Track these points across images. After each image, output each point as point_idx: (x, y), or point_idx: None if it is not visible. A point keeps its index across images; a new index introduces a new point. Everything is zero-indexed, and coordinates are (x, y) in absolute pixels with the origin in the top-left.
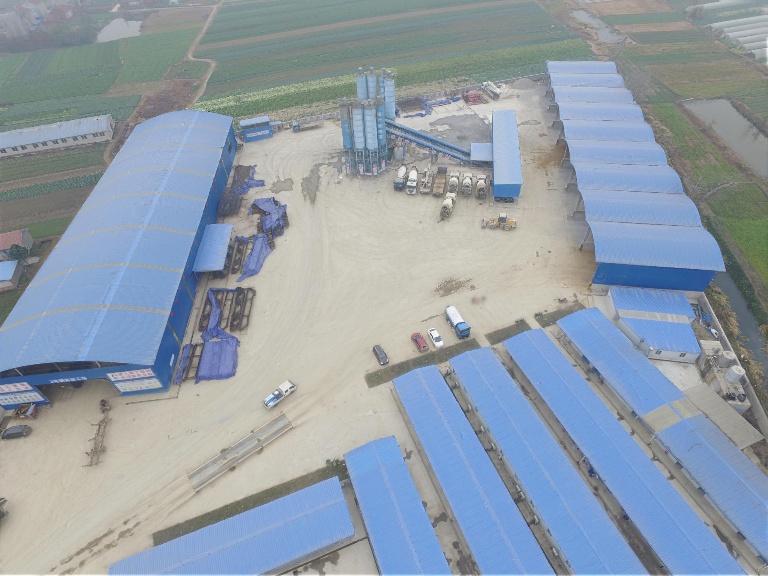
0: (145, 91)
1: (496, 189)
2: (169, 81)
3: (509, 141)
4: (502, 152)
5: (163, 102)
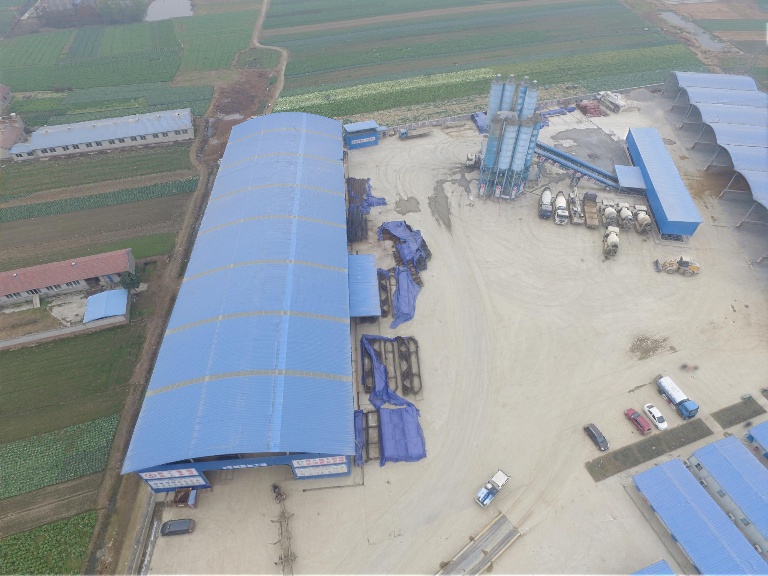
0: (216, 81)
1: (668, 226)
2: (240, 70)
3: (665, 167)
4: (662, 180)
5: (240, 95)
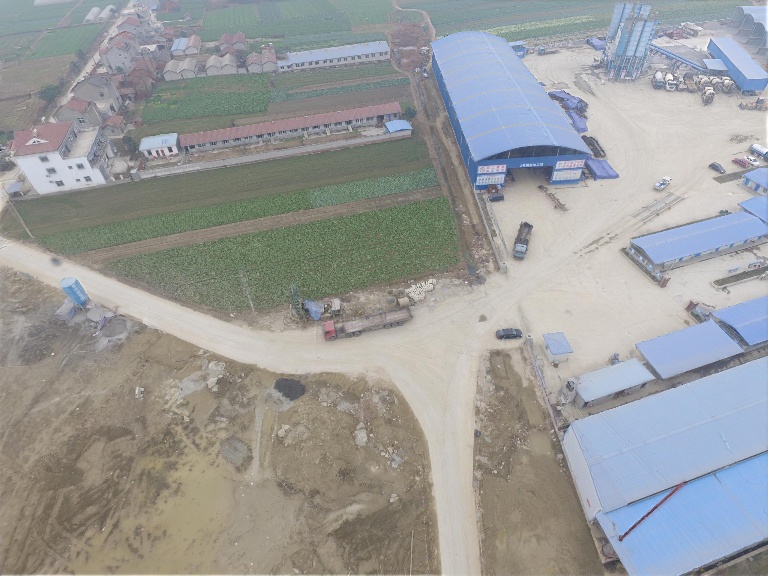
0: (383, 30)
1: (747, 83)
2: (397, 23)
3: (741, 55)
4: (740, 61)
5: (406, 37)
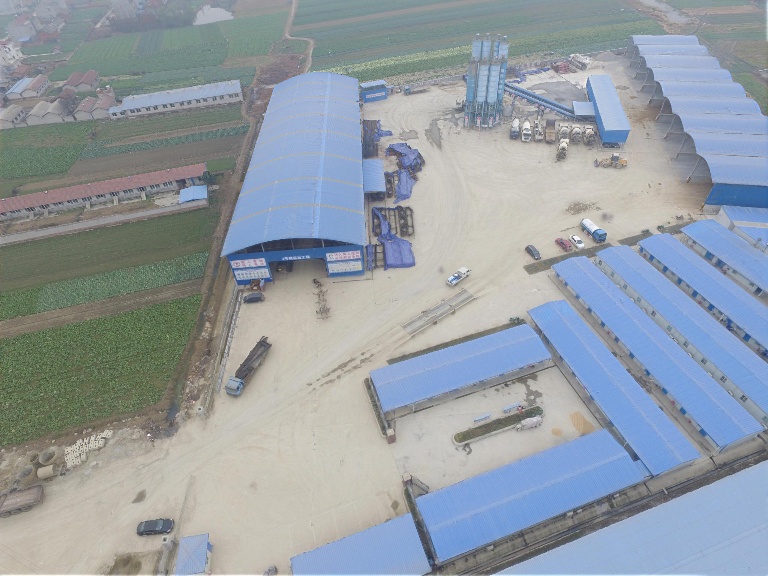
0: (257, 63)
1: (606, 135)
2: (276, 55)
3: (610, 98)
4: (606, 107)
5: (277, 72)
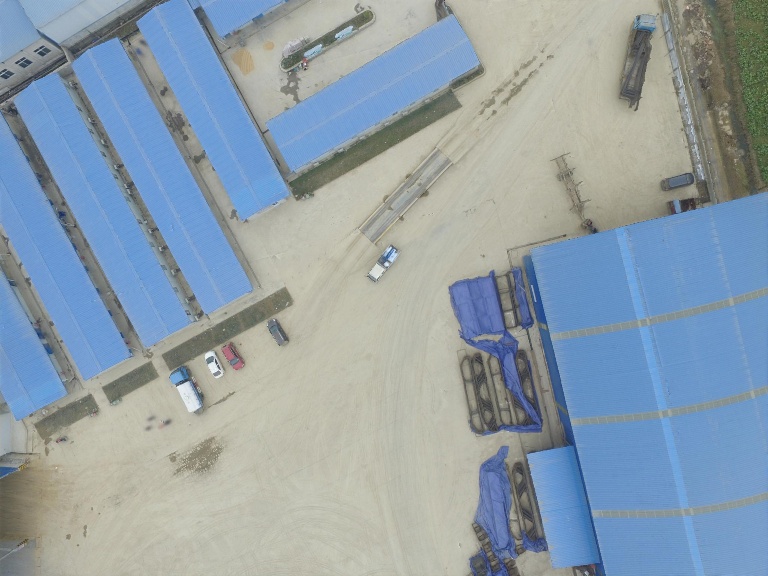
0: None
1: None
2: None
3: None
4: None
5: None
